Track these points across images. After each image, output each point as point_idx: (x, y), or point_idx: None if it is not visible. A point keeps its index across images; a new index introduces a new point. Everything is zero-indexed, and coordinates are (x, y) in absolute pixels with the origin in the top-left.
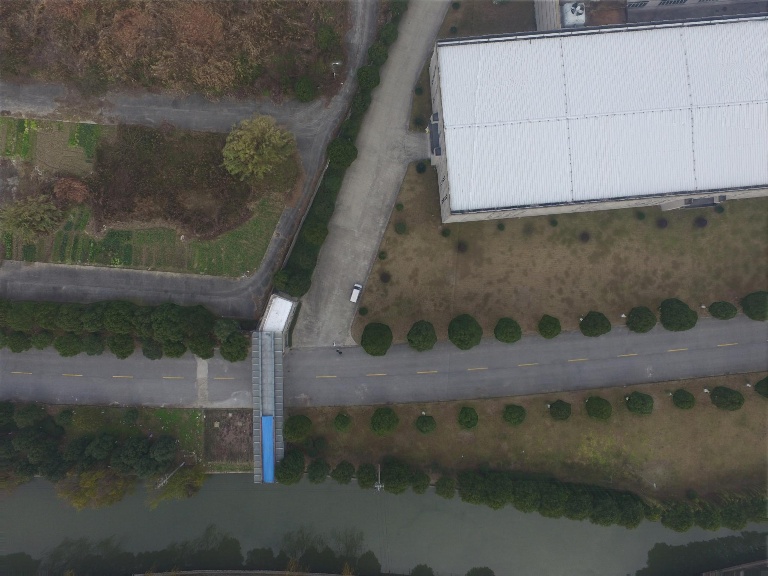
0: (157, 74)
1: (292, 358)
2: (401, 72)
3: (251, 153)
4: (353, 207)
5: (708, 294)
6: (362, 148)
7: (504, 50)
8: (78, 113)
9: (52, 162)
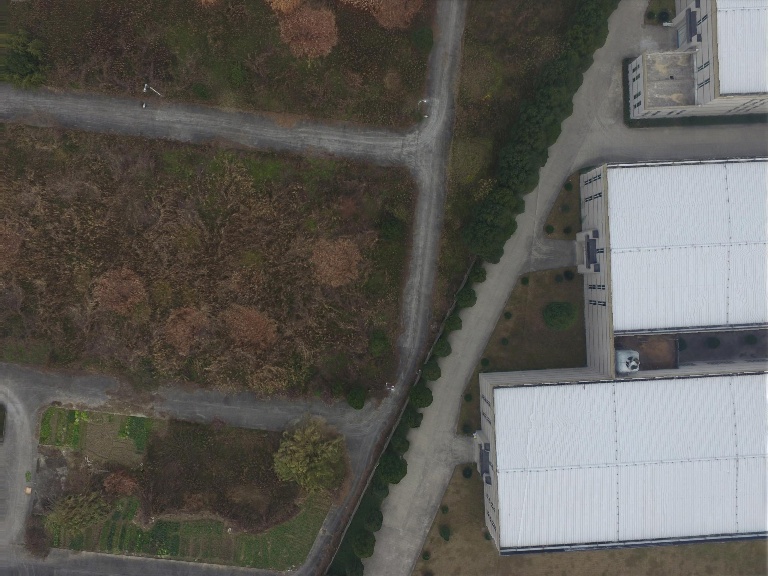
0: (210, 377)
1: None
2: (451, 377)
3: (304, 471)
4: (399, 507)
5: None
6: (410, 450)
7: (558, 394)
8: (129, 407)
9: (102, 452)
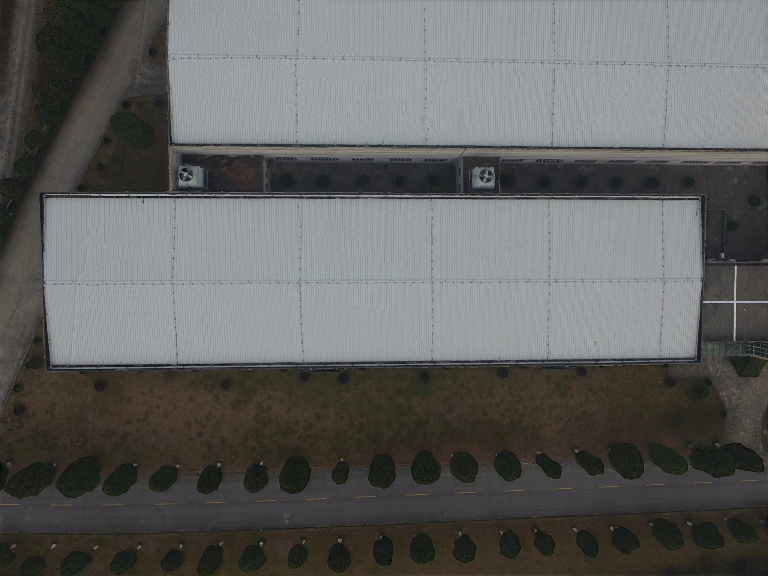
0: None
1: None
2: None
3: None
4: None
5: (349, 447)
6: (3, 277)
7: (115, 207)
8: None
9: None
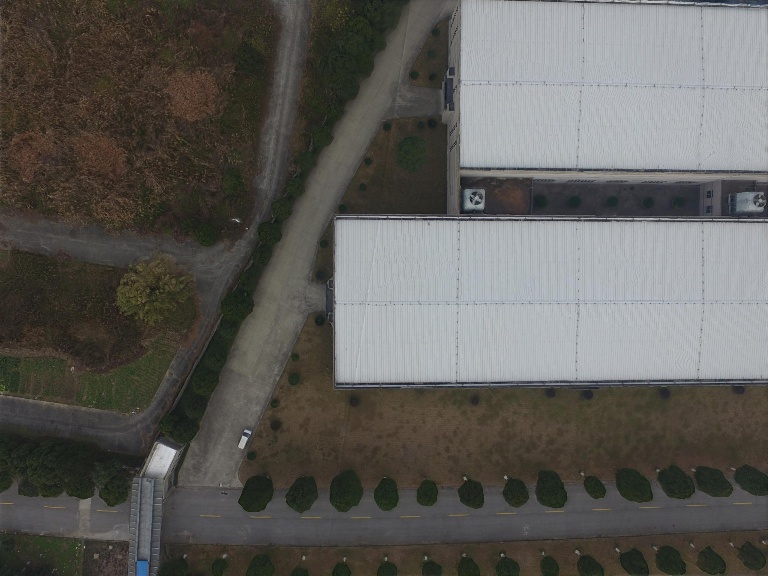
0: (54, 205)
1: (177, 496)
2: (308, 222)
3: (143, 301)
4: (249, 353)
5: (588, 461)
6: (263, 295)
7: (402, 229)
8: None
9: None
